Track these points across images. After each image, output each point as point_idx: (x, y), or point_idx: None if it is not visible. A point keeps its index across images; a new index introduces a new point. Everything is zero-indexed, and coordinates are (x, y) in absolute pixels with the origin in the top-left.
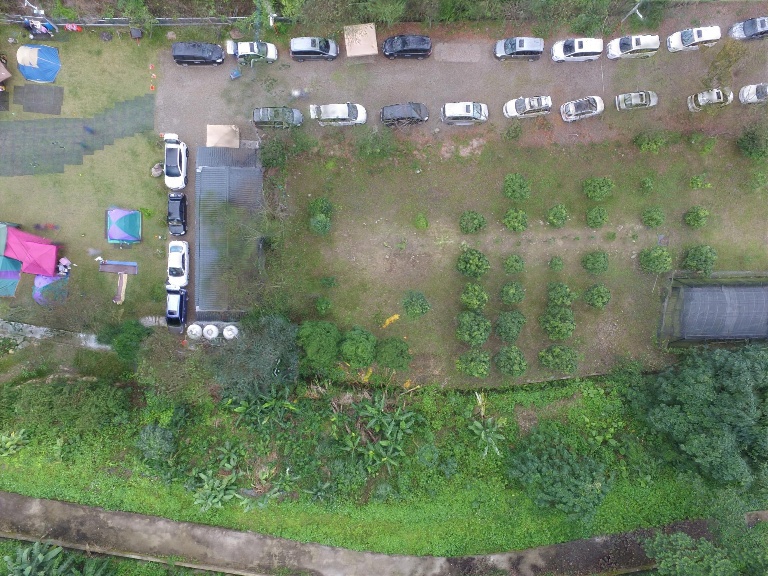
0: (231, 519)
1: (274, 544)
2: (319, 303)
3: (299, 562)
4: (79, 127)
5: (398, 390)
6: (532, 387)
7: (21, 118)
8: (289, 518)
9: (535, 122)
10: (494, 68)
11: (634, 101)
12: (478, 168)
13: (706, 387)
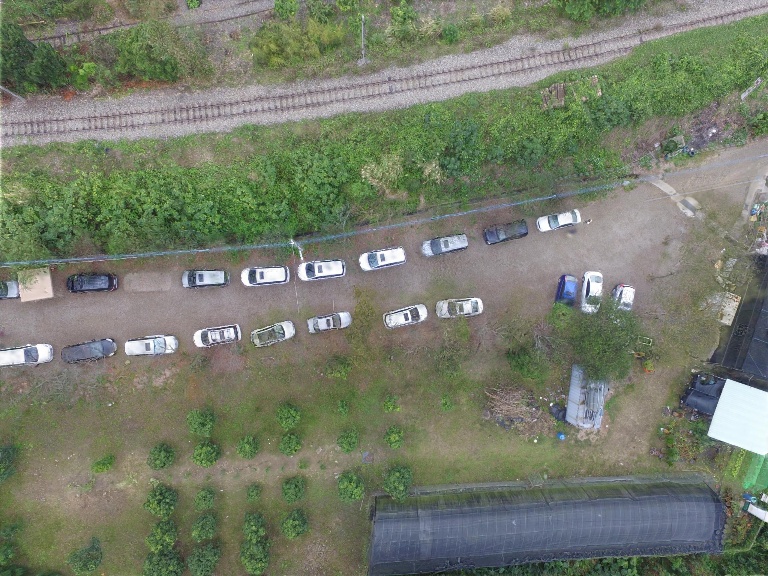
0: None
1: None
2: None
3: None
4: None
5: None
6: None
7: None
8: None
9: (229, 347)
10: (185, 296)
11: (321, 327)
12: (173, 397)
13: None
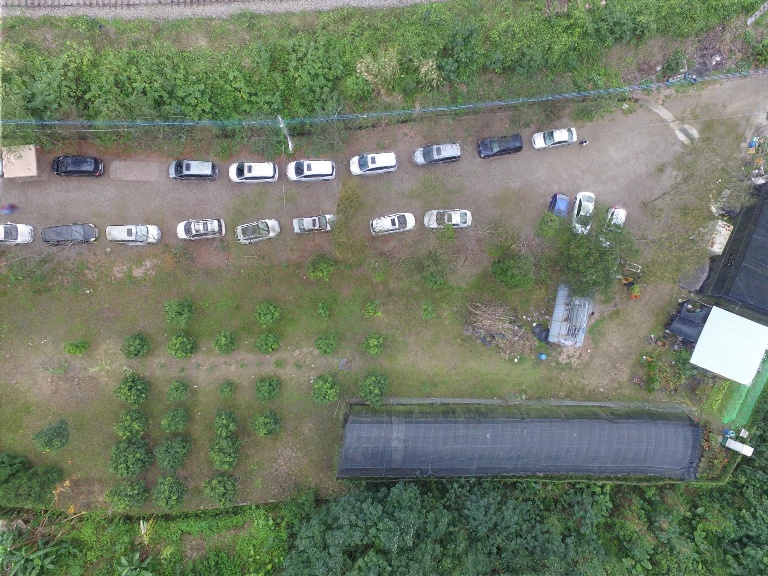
0: None
1: None
2: None
3: None
4: None
5: (63, 515)
6: (207, 513)
7: None
8: None
9: (212, 243)
10: (171, 187)
11: (306, 226)
12: (152, 288)
13: (316, 542)
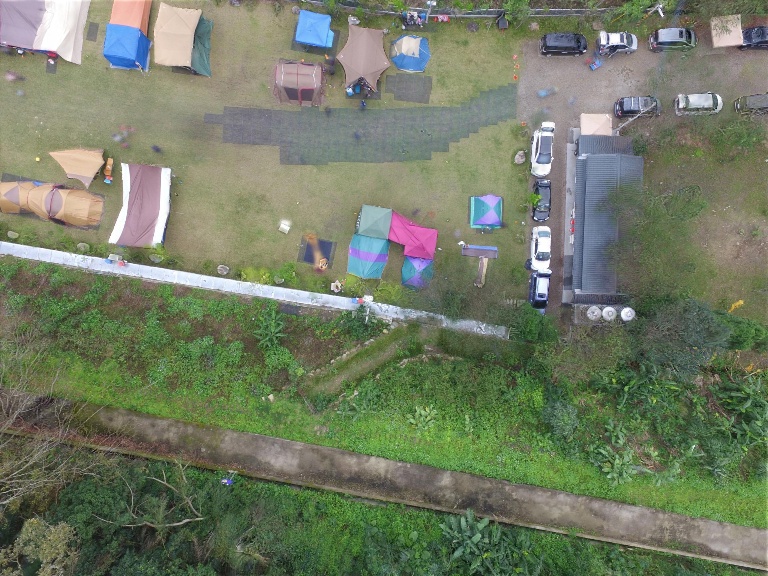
0: (624, 493)
1: (666, 518)
2: None
3: (689, 536)
4: (446, 115)
5: (739, 373)
6: None
7: (392, 106)
8: (678, 493)
9: None
10: None
11: None
12: None
13: None
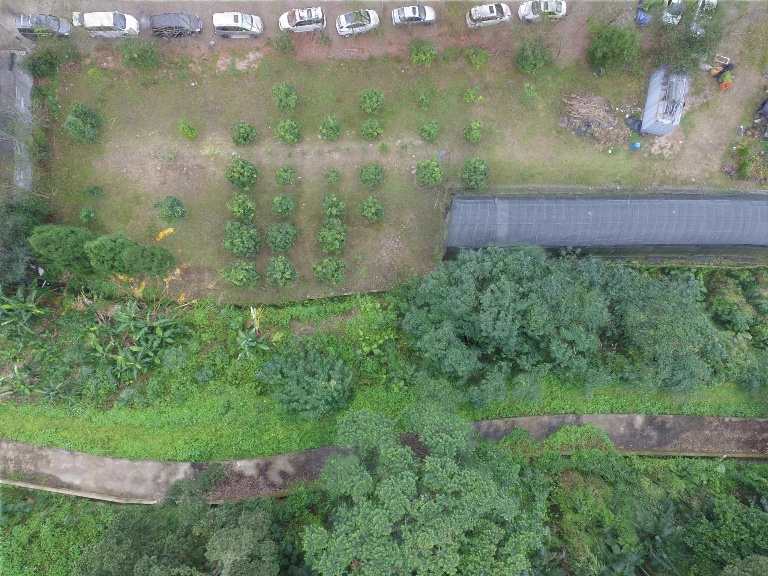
0: None
1: (10, 448)
2: (81, 211)
3: (36, 466)
4: None
5: (173, 305)
6: (313, 303)
7: None
8: (27, 422)
9: (313, 36)
10: None
11: (406, 14)
12: (255, 82)
13: (442, 284)
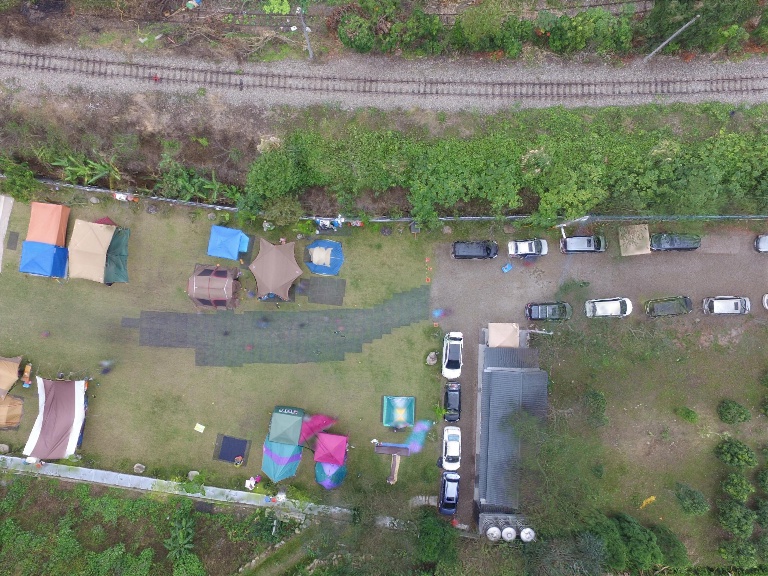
0: None
1: None
2: (589, 492)
3: None
4: (359, 317)
5: (651, 567)
6: None
7: (306, 309)
8: None
9: None
10: (753, 259)
11: None
12: (735, 356)
13: None
